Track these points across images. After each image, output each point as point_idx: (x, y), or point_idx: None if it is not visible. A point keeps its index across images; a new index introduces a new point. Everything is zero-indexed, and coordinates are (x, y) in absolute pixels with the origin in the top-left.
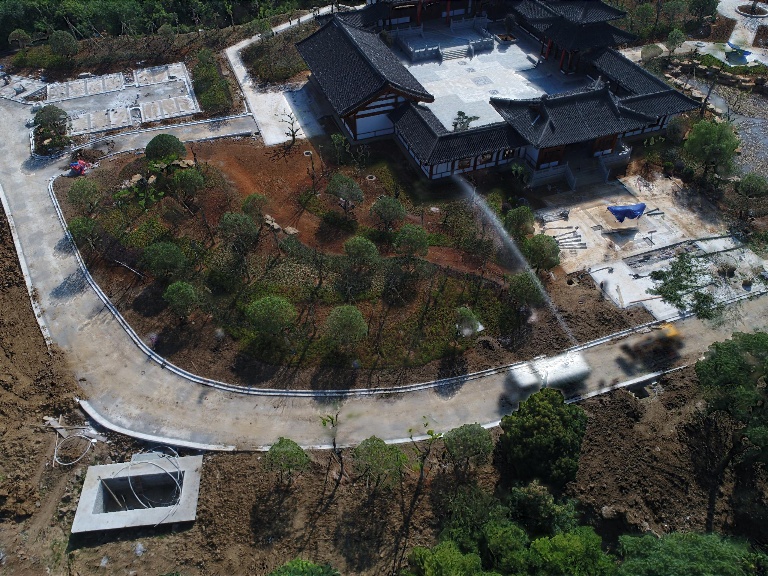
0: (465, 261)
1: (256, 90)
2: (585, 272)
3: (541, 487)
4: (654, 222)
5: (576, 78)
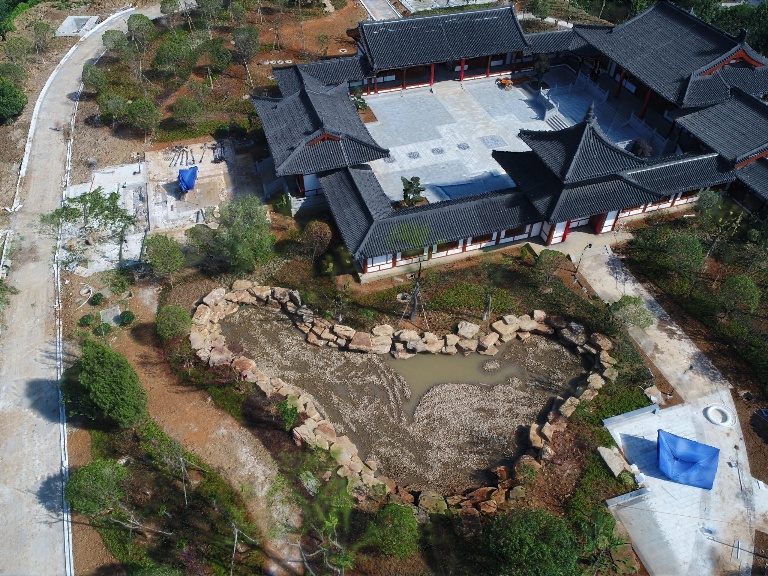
0: None
1: None
2: None
3: None
4: (186, 213)
5: None
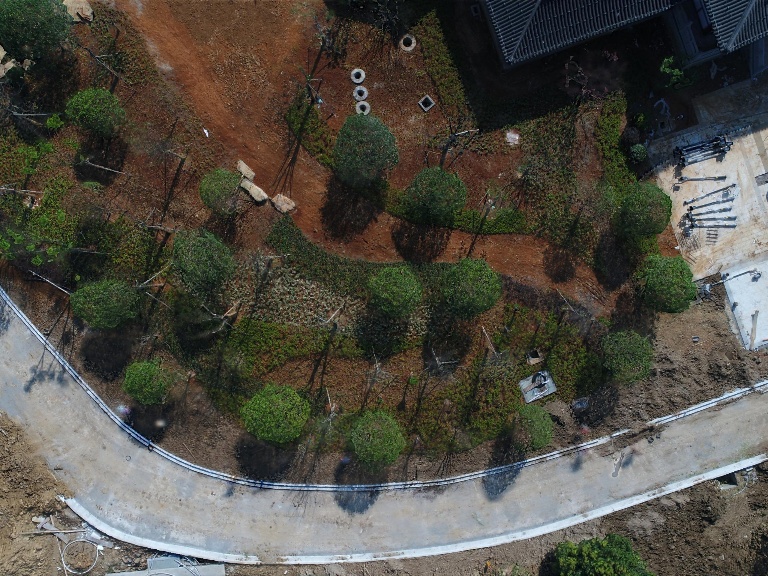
0: (547, 265)
1: None
2: (718, 278)
3: None
4: None
5: None
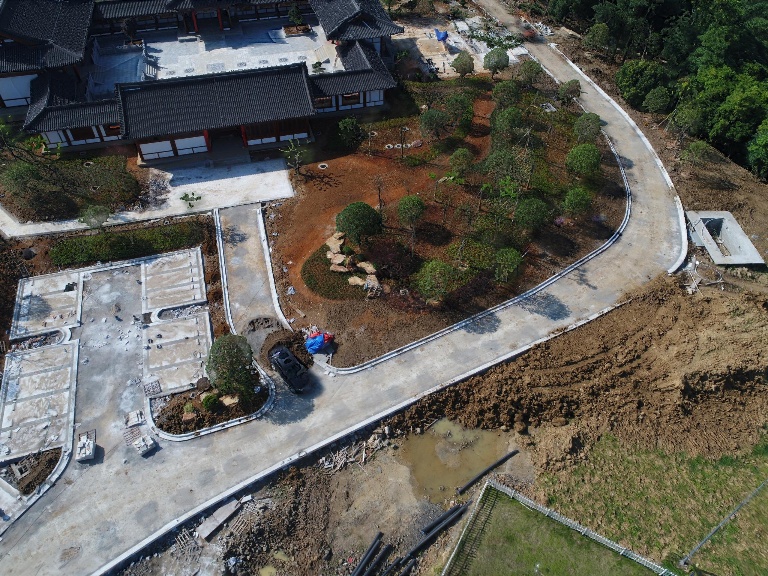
0: (487, 100)
1: (153, 208)
2: None
3: None
4: None
5: (240, 26)
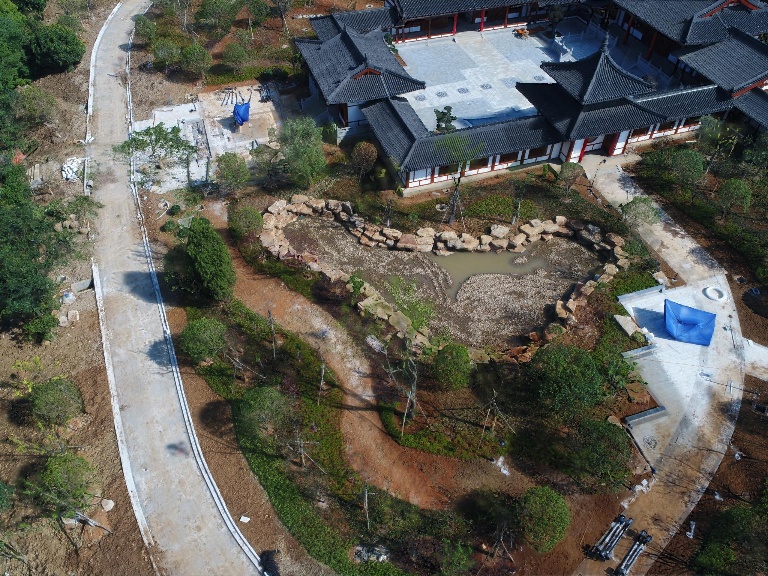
0: None
1: None
2: None
3: (25, 30)
4: (242, 143)
5: None
